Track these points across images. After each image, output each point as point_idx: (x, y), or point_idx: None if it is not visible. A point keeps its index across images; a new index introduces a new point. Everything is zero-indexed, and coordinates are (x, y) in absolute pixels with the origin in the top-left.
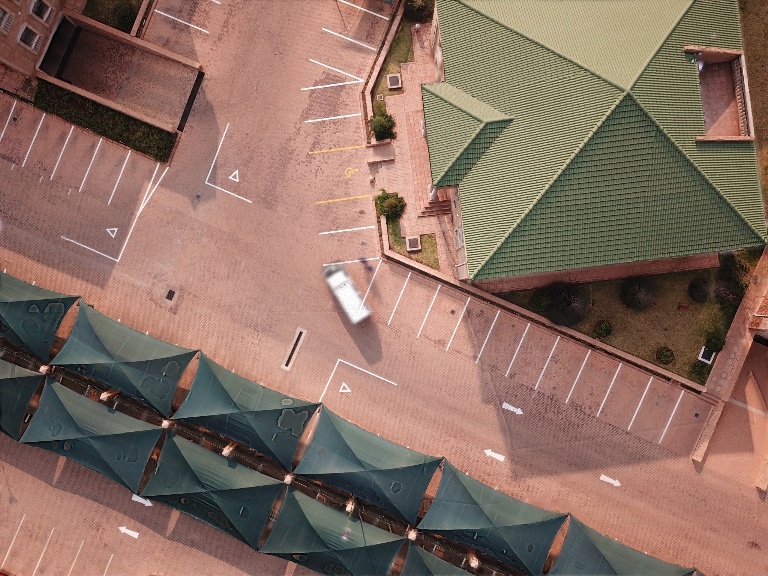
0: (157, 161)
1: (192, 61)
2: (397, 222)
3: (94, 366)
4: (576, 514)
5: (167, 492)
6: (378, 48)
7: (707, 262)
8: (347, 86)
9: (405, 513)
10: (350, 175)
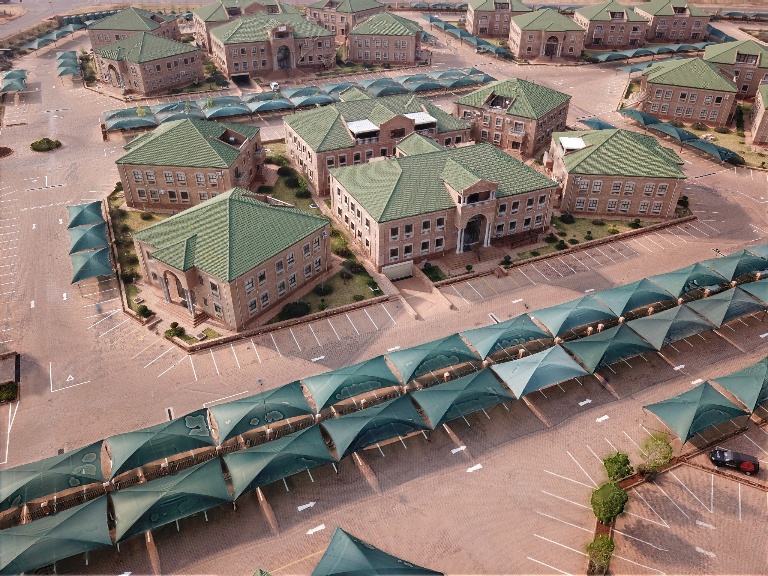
0: (9, 402)
1: (9, 352)
2: (184, 335)
3: (26, 486)
4: (395, 369)
5: (136, 517)
6: (120, 297)
7: (339, 269)
8: (113, 315)
9: (302, 408)
10: (142, 339)
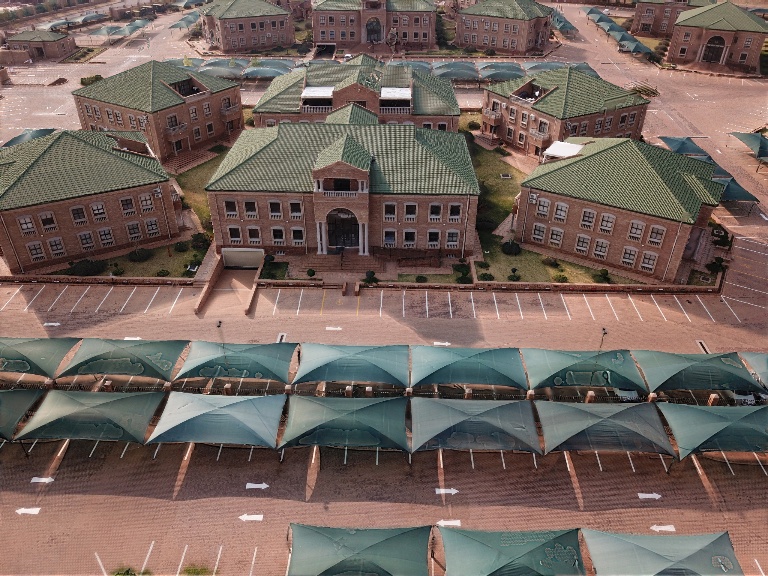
0: None
1: None
2: None
3: None
4: (103, 361)
5: None
6: None
7: (185, 239)
8: None
9: None
10: None
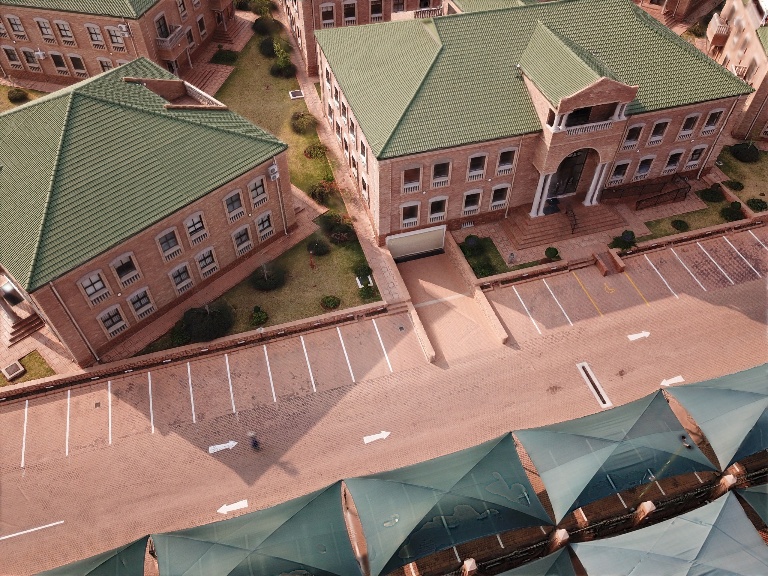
0: None
1: None
2: None
3: None
4: None
5: None
6: None
7: (309, 230)
8: None
9: None
10: None
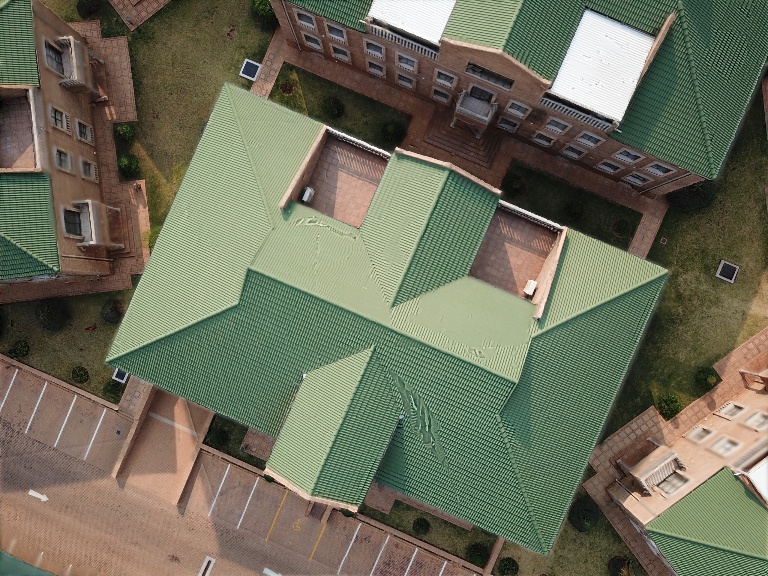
0: None
1: None
2: None
3: None
4: (4, 528)
5: None
6: None
7: (121, 284)
8: None
9: None
10: None
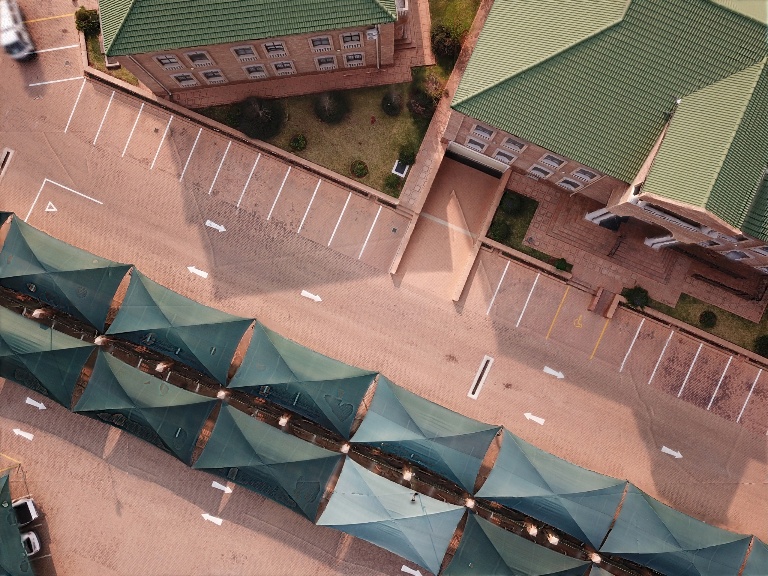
0: None
1: None
2: (96, 39)
3: None
4: (277, 329)
5: None
6: None
7: (400, 77)
8: None
9: (89, 317)
10: None
